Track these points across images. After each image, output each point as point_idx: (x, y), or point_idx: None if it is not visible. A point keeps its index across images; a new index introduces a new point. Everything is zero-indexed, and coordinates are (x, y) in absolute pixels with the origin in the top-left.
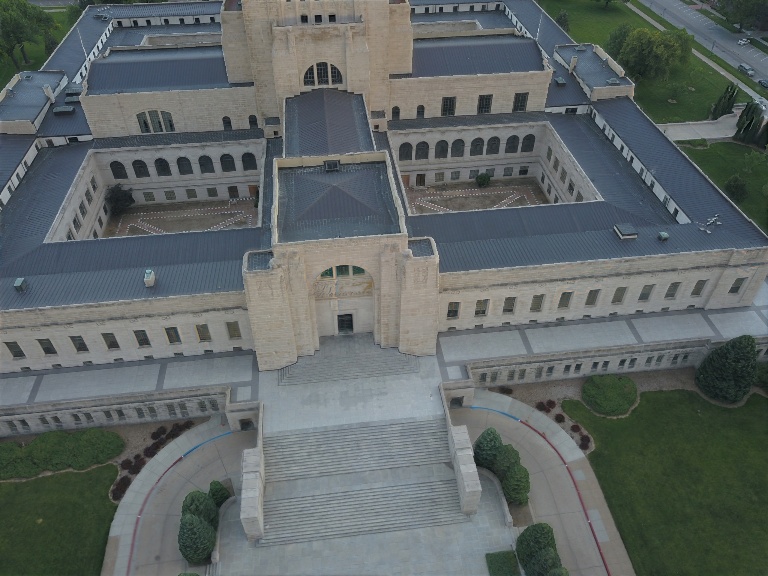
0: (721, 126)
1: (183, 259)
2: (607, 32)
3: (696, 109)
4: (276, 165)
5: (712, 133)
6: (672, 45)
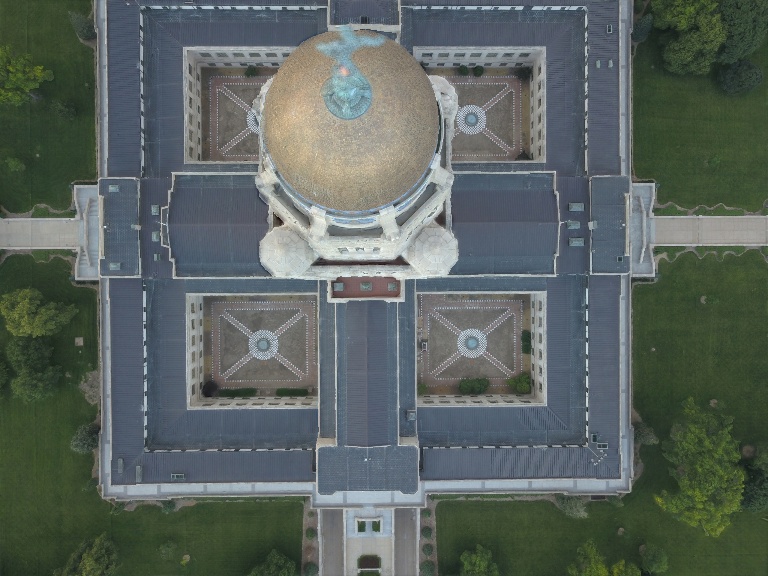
0: (4, 240)
1: (459, 26)
2: (12, 492)
3: (8, 278)
4: (399, 19)
5: (19, 229)
6: (7, 303)
